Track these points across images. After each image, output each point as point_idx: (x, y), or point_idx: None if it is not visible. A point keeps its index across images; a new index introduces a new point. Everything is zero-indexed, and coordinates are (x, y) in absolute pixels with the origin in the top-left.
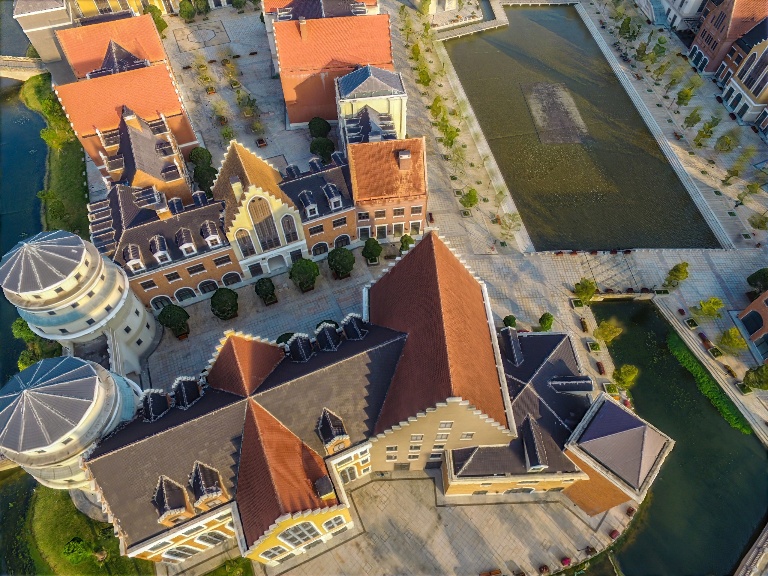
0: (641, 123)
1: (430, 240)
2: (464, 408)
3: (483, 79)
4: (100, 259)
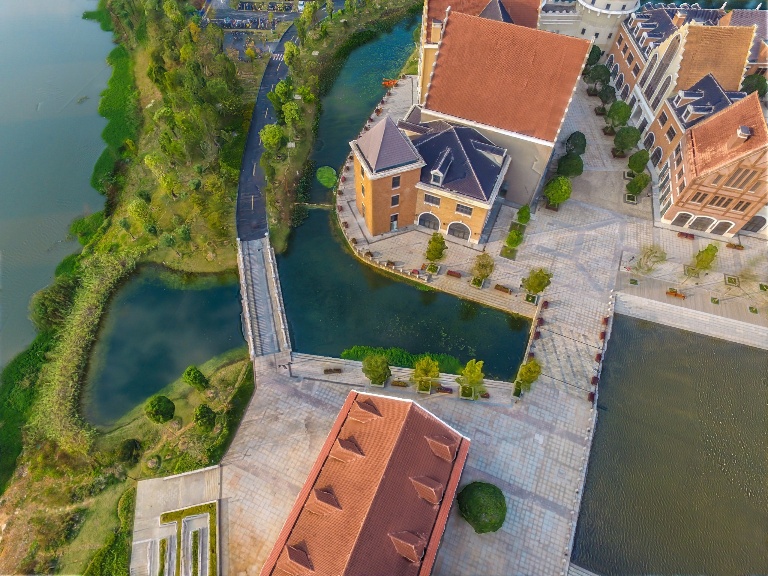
0: None
1: None
2: None
3: None
4: None
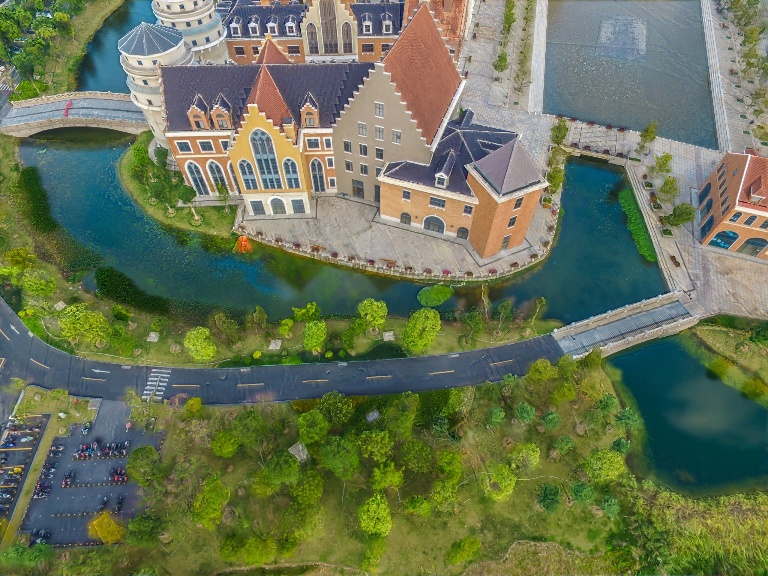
0: (703, 58)
1: None
2: (387, 81)
3: (570, 3)
4: (212, 3)
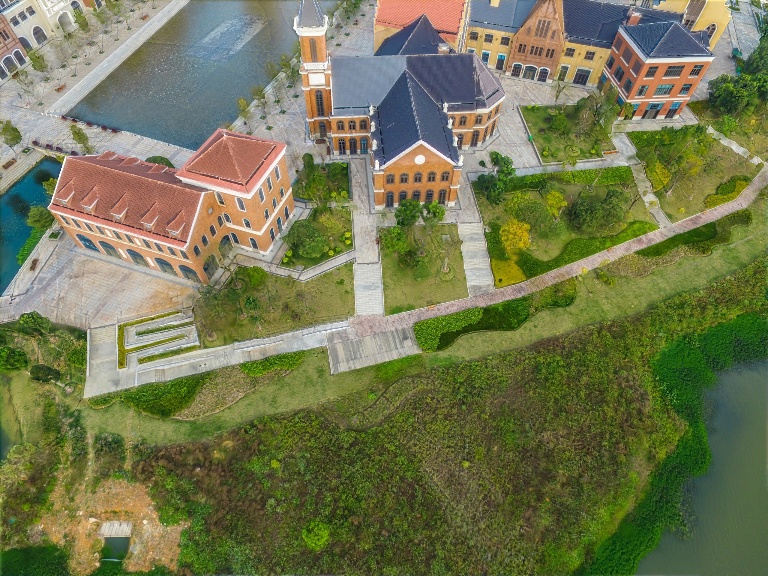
0: (288, 58)
1: None
2: None
3: (211, 3)
4: None
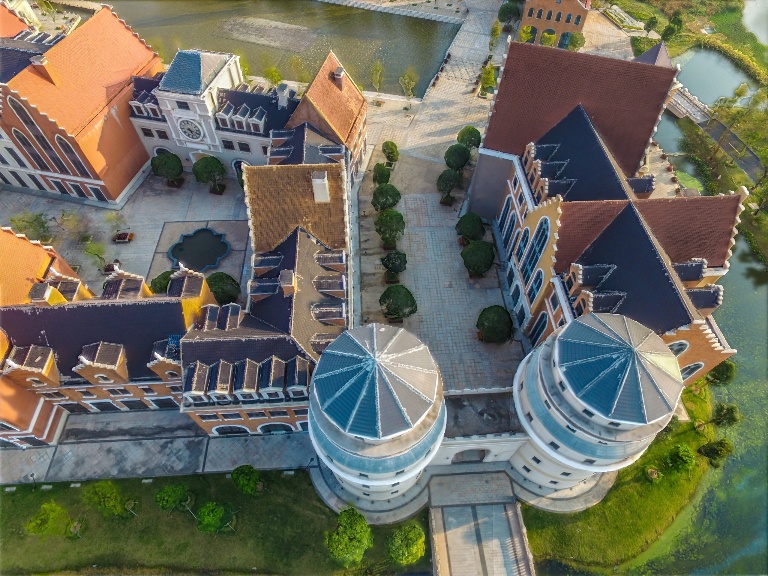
0: (319, 3)
1: (519, 45)
2: None
3: None
4: None
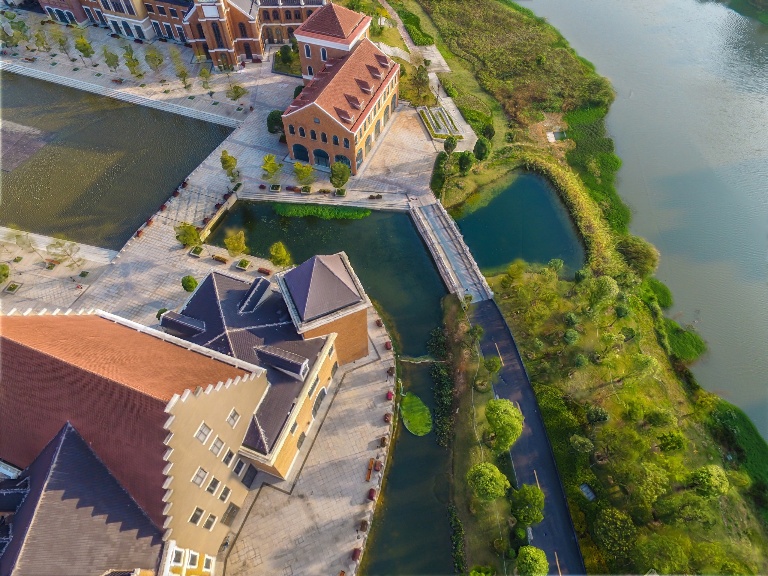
0: (78, 92)
1: None
2: (192, 399)
3: None
4: None
